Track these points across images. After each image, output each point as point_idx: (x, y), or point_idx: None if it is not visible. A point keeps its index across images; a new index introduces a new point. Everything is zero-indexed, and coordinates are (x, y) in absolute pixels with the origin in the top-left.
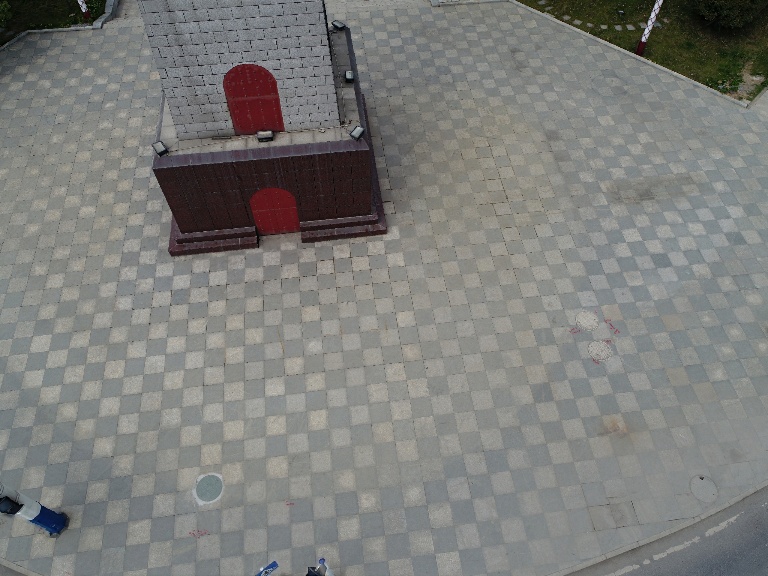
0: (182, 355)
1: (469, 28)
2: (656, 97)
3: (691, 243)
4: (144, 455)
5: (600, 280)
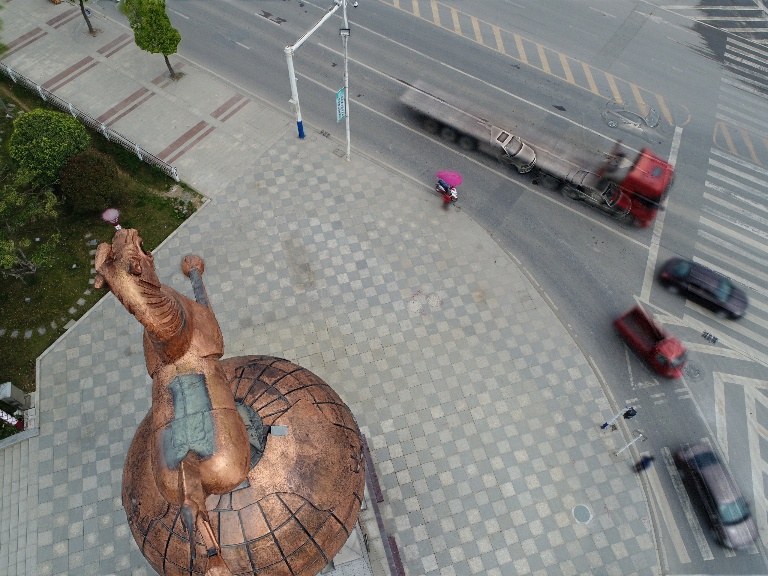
0: (502, 568)
1: (85, 395)
2: (198, 252)
3: (345, 248)
4: (577, 567)
5: (383, 298)
